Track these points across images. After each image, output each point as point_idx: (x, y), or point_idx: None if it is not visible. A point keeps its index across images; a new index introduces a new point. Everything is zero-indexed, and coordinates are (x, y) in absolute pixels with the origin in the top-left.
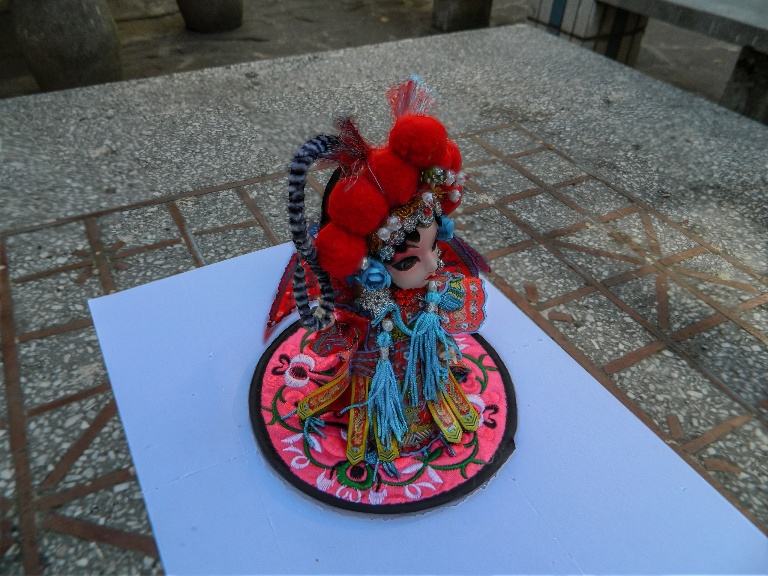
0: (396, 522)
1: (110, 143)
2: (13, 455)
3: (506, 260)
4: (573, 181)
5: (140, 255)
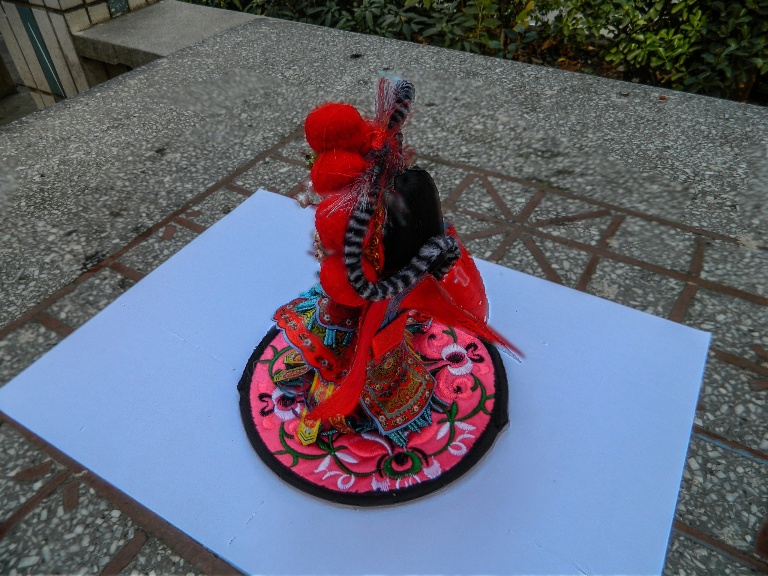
0: None
1: None
2: (568, 240)
3: None
4: None
5: None
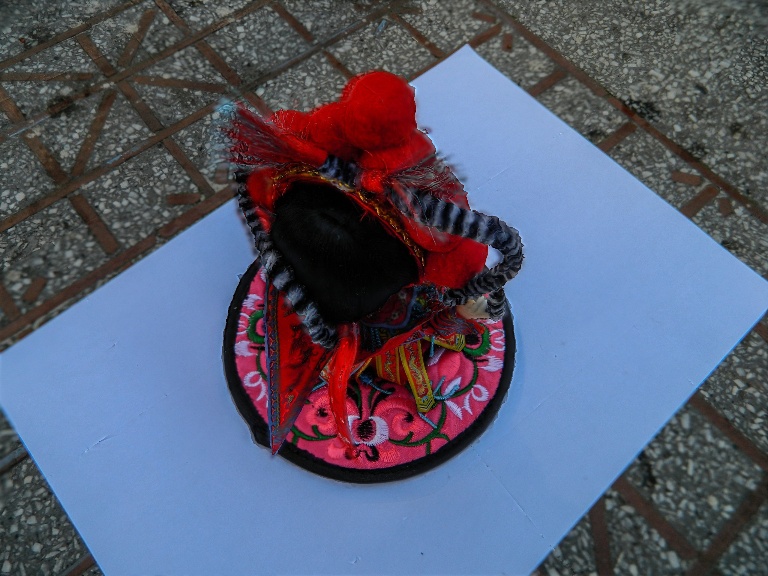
0: None
1: None
2: None
3: (119, 226)
4: None
5: None
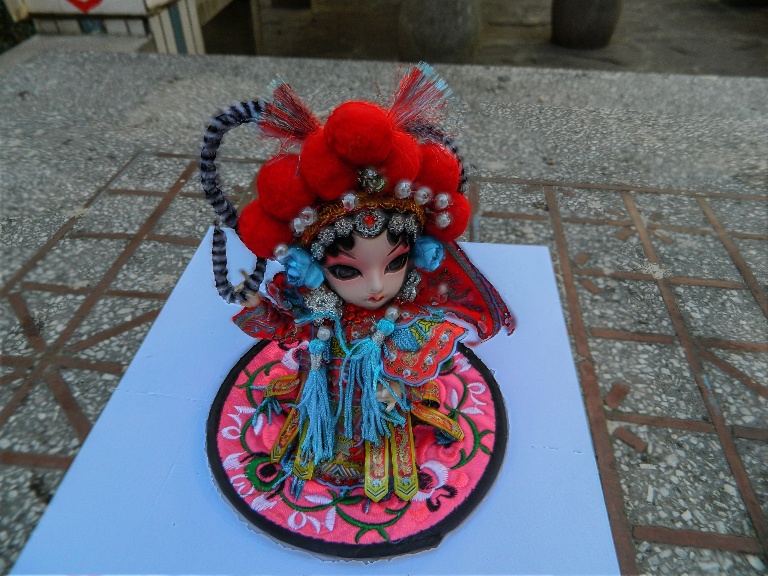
0: (261, 538)
1: (333, 109)
2: (74, 317)
3: (617, 345)
4: None
5: None
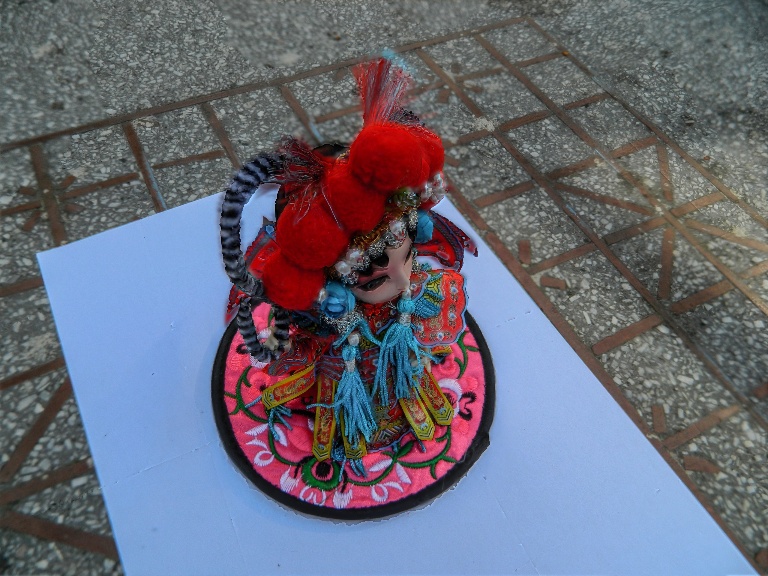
0: (361, 525)
1: (55, 38)
2: None
3: (500, 208)
4: (586, 101)
5: (93, 195)
